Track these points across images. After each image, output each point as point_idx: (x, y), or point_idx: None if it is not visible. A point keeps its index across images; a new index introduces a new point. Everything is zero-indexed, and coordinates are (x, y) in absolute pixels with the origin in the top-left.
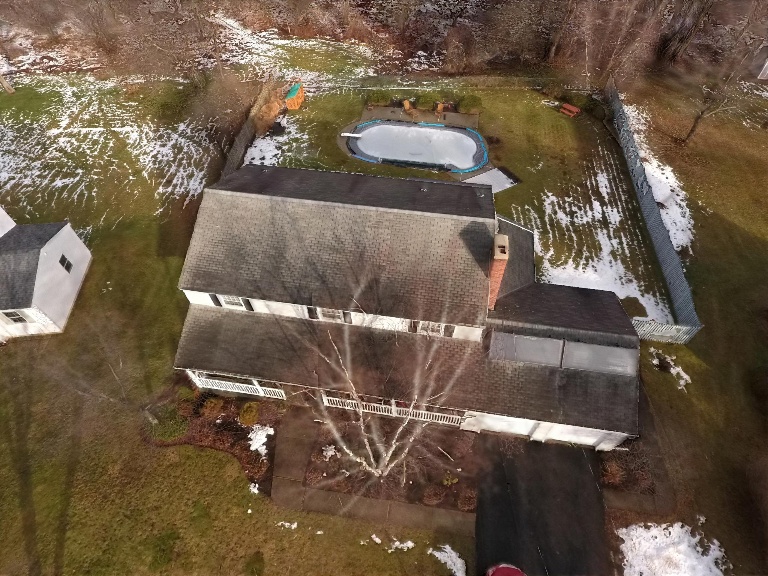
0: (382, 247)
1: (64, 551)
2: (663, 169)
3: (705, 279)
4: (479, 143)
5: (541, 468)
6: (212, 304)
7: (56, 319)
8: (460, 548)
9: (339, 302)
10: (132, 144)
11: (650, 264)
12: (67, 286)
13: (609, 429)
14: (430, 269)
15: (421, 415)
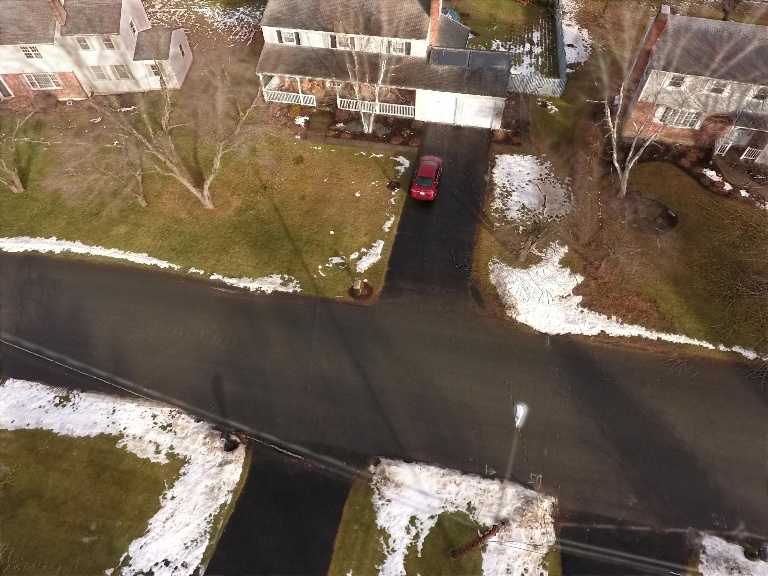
0: (373, 4)
1: (198, 155)
2: (581, 30)
3: (585, 74)
4: (454, 16)
5: (458, 135)
6: (277, 42)
7: (178, 78)
8: (408, 157)
9: (348, 30)
10: (208, 17)
11: (553, 68)
12: (182, 64)
13: (491, 96)
14: (399, 14)
15: (392, 108)
